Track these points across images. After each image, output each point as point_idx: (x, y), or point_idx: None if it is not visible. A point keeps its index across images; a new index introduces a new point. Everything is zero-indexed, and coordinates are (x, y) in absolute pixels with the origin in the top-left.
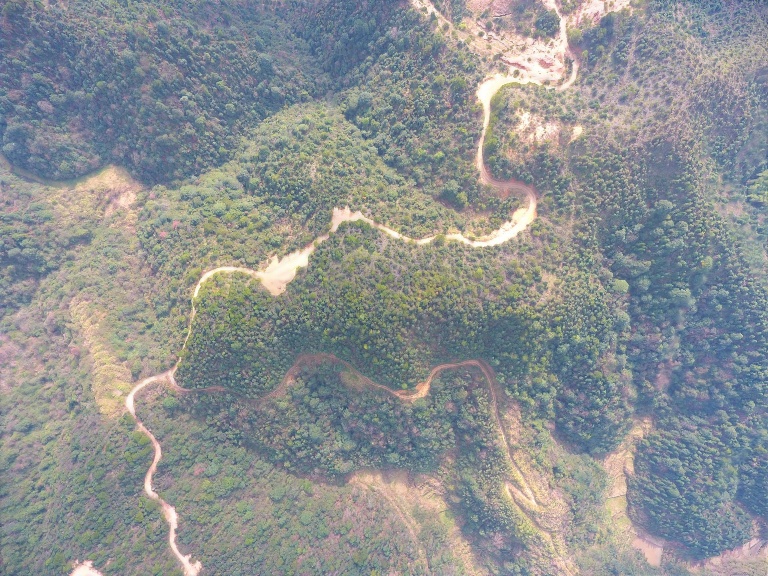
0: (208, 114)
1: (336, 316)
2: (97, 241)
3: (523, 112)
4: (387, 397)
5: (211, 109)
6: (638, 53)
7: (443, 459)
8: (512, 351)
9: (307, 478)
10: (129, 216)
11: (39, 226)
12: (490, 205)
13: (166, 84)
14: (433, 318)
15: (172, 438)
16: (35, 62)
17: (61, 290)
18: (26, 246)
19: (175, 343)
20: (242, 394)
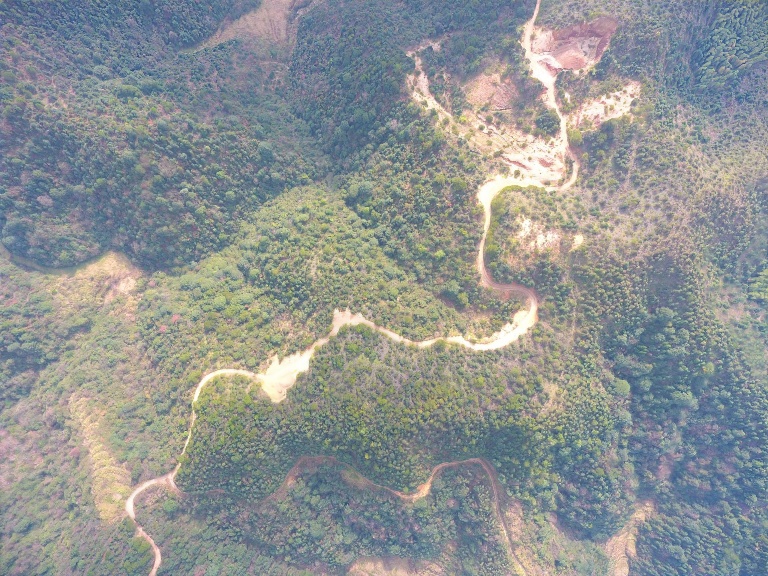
0: (208, 203)
1: (337, 429)
2: (97, 330)
3: (524, 219)
4: (388, 497)
5: (211, 198)
6: (639, 161)
7: (444, 547)
8: (514, 456)
9: (308, 568)
10: (129, 303)
11: (38, 318)
12: (491, 306)
13: (166, 178)
14: (434, 428)
15: (172, 542)
16: (35, 160)
17: (60, 386)
18: (25, 340)
19: (175, 446)
20: (242, 498)
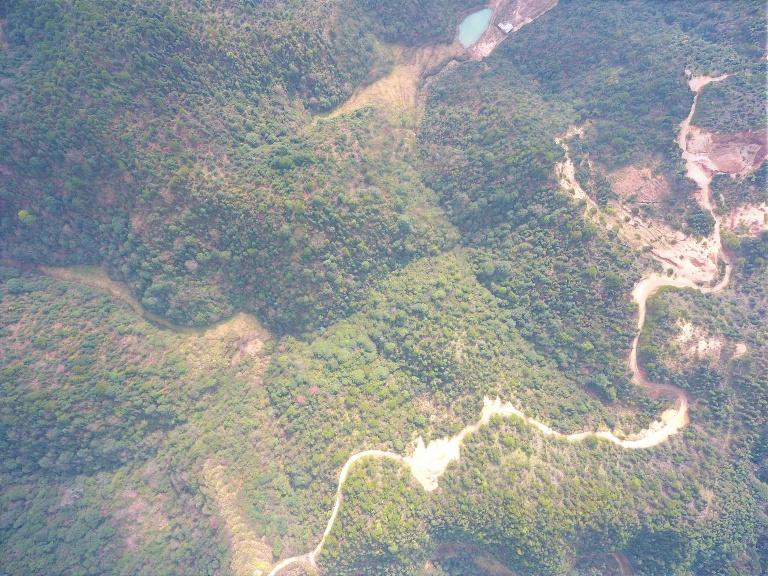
0: (345, 272)
1: (497, 526)
2: (226, 393)
3: (684, 323)
4: None
5: (348, 267)
6: None
7: None
8: (659, 556)
9: None
10: (257, 365)
11: (173, 380)
12: (639, 403)
13: (314, 250)
14: (589, 527)
15: None
16: (189, 226)
17: (196, 451)
18: (162, 403)
19: (318, 525)
20: None
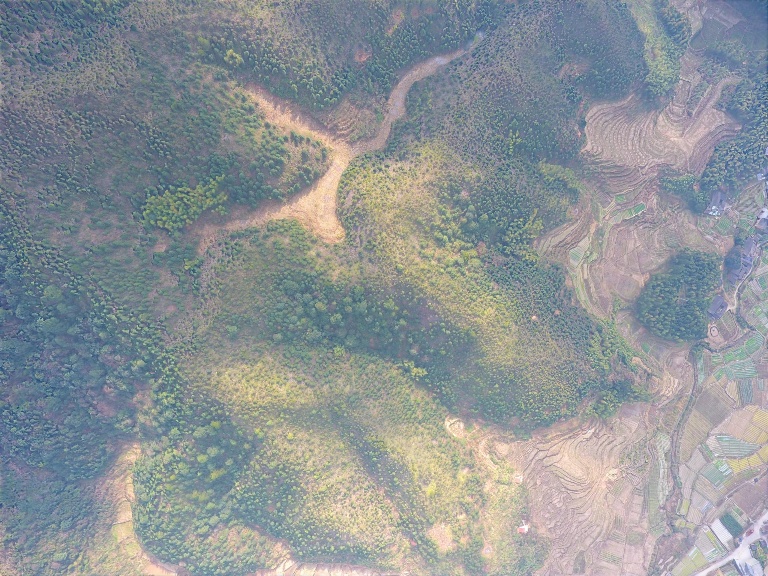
0: None
1: None
2: None
3: None
4: None
5: None
6: None
7: None
8: None
9: None
10: None
11: None
12: None
13: None
14: None
15: None
16: None
17: None
18: None
19: None
20: None
